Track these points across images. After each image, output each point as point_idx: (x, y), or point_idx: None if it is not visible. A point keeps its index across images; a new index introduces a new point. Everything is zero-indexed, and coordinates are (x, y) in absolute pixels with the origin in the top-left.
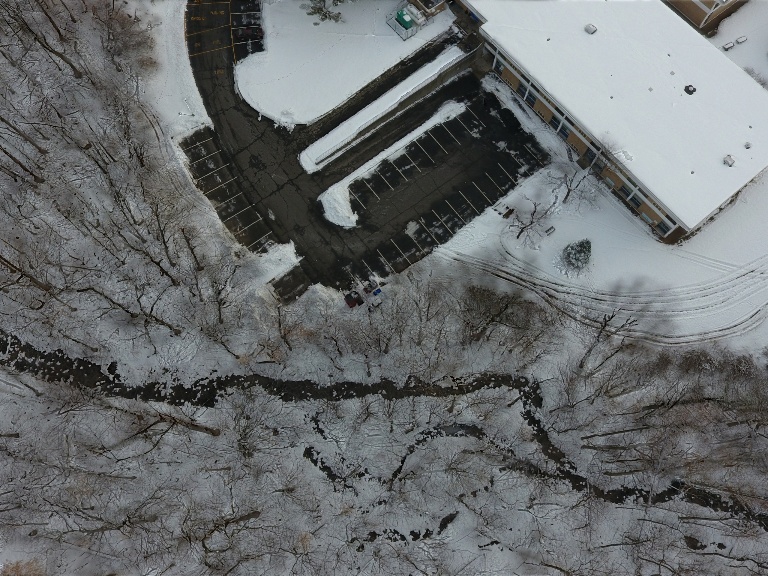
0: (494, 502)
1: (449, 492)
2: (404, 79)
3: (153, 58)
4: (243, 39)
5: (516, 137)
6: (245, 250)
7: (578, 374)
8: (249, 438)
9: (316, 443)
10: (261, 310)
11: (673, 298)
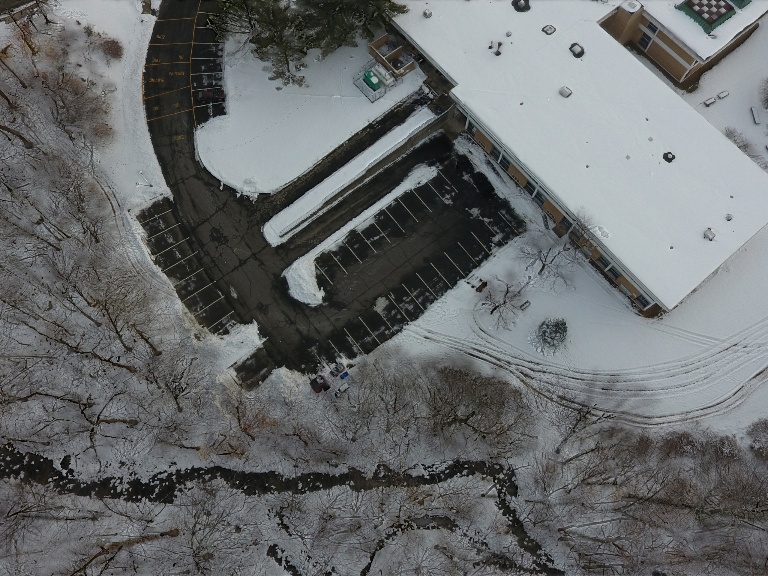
0: None
1: None
2: (372, 144)
3: (109, 124)
4: (204, 102)
5: (490, 203)
6: (205, 332)
7: (554, 460)
8: (209, 538)
9: (280, 540)
10: (222, 397)
11: (653, 376)
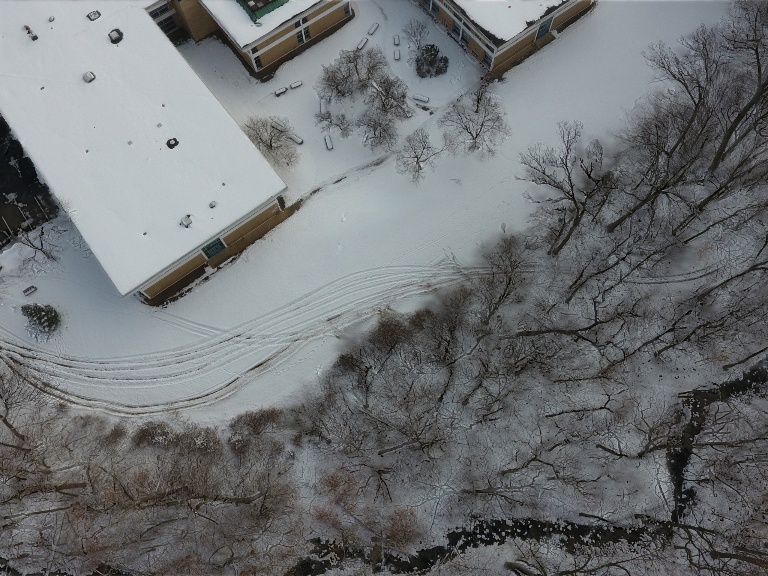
0: None
1: None
2: None
3: None
4: None
5: (29, 188)
6: None
7: None
8: None
9: None
10: None
11: (143, 365)
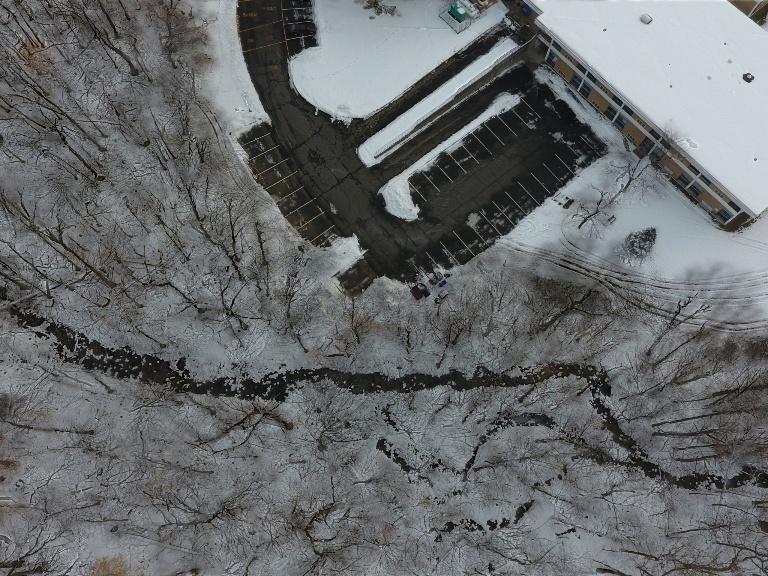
0: (569, 490)
1: (524, 481)
2: (459, 72)
3: (208, 54)
4: (296, 34)
5: (572, 128)
6: (309, 244)
7: (646, 362)
8: None
9: (388, 435)
10: (328, 303)
11: (736, 285)
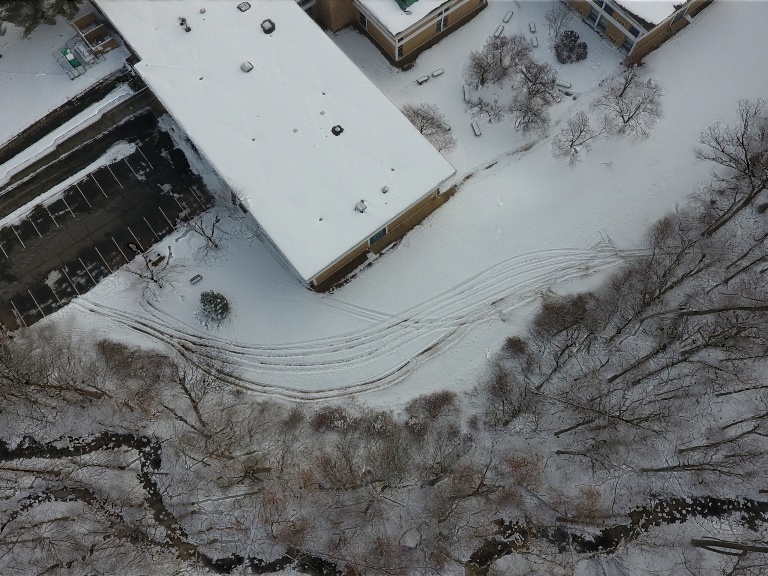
0: None
1: (37, 563)
2: (68, 120)
3: None
4: None
5: (183, 179)
6: None
7: (199, 434)
8: None
9: None
10: None
11: (315, 350)
